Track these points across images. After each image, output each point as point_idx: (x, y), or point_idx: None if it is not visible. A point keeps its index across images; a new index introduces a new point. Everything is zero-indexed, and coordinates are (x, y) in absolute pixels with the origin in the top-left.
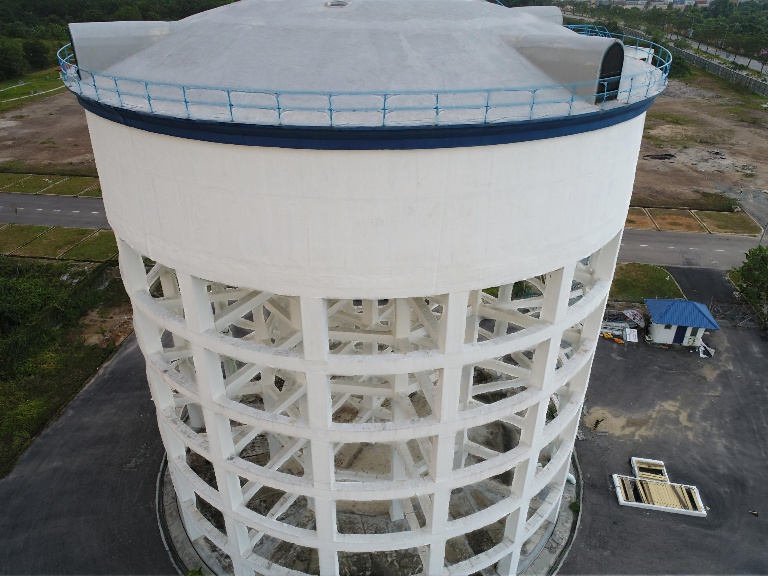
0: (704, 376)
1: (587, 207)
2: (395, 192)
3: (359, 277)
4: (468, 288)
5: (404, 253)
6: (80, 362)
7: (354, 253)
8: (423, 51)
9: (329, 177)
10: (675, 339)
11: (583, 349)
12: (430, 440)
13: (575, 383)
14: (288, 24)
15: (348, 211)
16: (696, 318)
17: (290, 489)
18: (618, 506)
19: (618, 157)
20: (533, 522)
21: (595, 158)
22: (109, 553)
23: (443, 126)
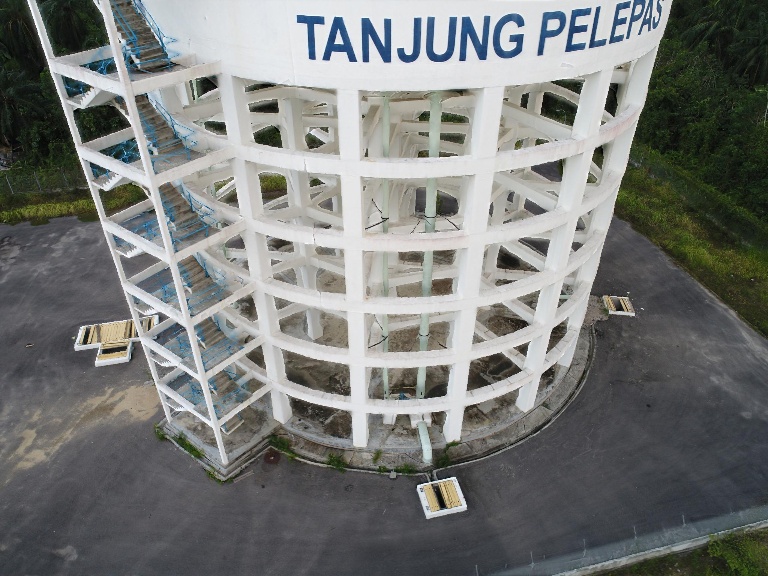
0: None
1: None
2: None
3: None
4: None
5: None
6: (765, 312)
7: None
8: None
9: None
10: None
11: None
12: None
13: None
14: None
15: None
16: None
17: None
18: (161, 315)
19: None
20: None
21: None
22: None
23: None
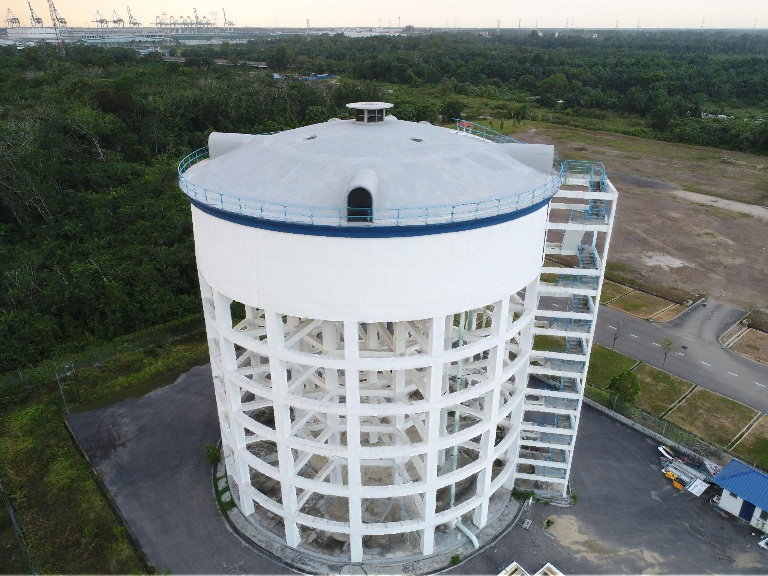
0: (733, 559)
1: (358, 287)
2: (236, 244)
3: (227, 285)
4: (274, 310)
5: (242, 278)
6: None
7: (225, 271)
8: (298, 173)
9: (215, 229)
10: (742, 513)
11: (412, 402)
12: (408, 461)
13: (425, 434)
14: (273, 147)
15: (221, 248)
16: (765, 498)
17: (222, 403)
18: None
19: (390, 261)
20: (376, 526)
21: (357, 256)
22: (201, 422)
23: (242, 215)
